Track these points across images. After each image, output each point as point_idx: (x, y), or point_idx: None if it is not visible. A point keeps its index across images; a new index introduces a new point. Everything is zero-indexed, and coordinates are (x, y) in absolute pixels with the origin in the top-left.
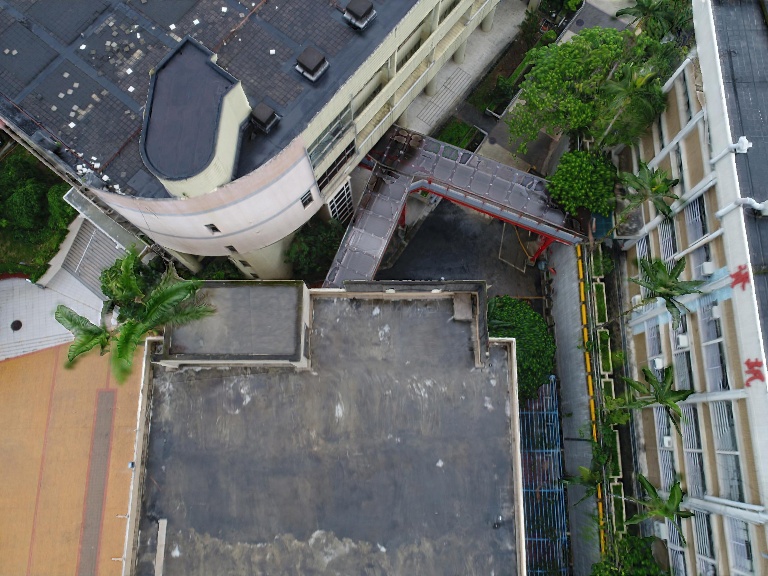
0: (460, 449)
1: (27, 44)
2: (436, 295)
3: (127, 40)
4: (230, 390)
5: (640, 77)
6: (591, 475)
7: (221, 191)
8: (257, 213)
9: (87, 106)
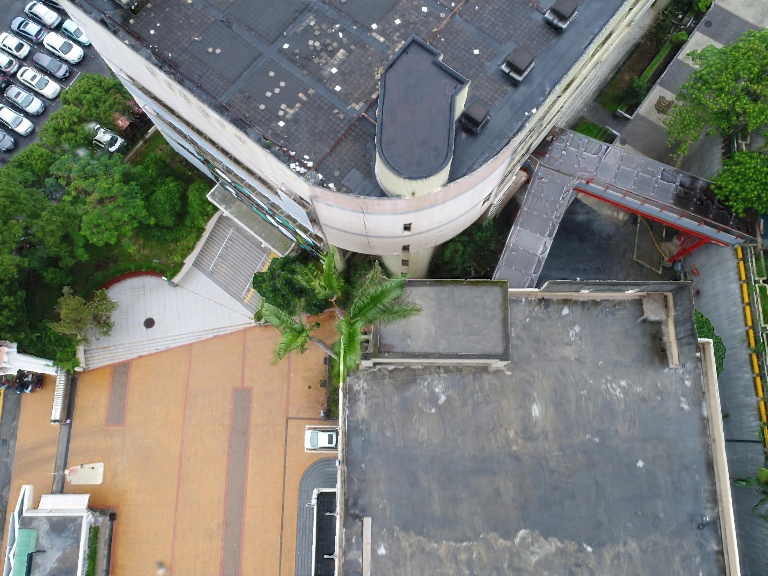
0: (659, 449)
1: (230, 43)
2: (626, 295)
3: (329, 39)
4: (425, 389)
5: None
6: None
7: (443, 190)
8: (452, 212)
9: (295, 105)
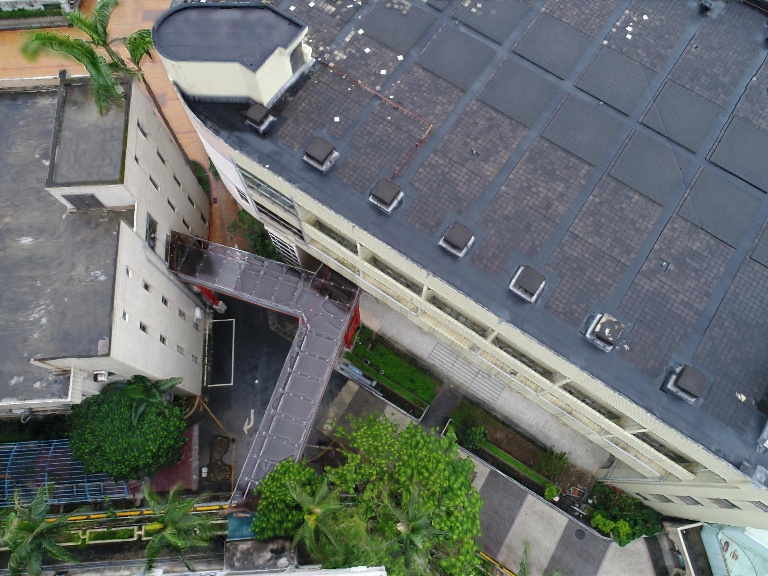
0: None
1: None
2: None
3: None
4: None
5: (316, 517)
6: None
7: None
8: None
9: None
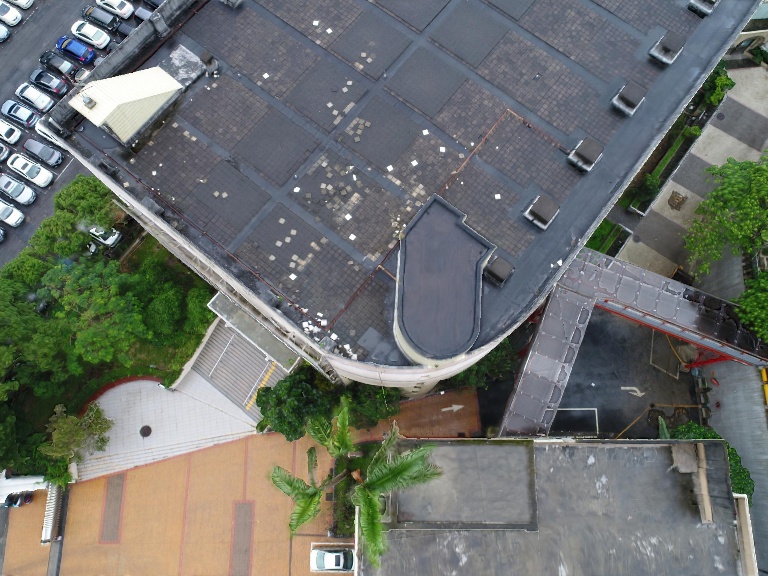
0: None
1: (237, 186)
2: None
3: (343, 182)
4: (444, 549)
5: None
6: None
7: (467, 357)
8: (472, 360)
9: (307, 255)
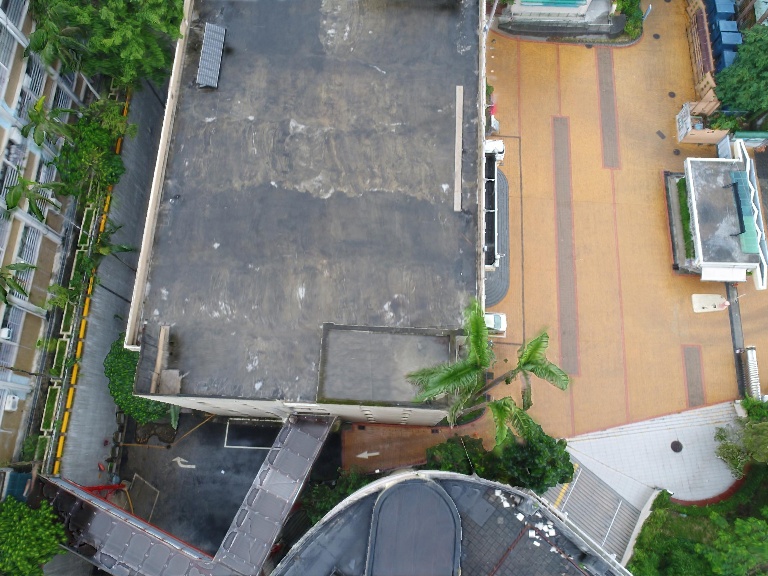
0: (197, 257)
1: None
2: None
3: None
4: (403, 316)
5: None
6: (99, 248)
7: None
8: None
9: None
